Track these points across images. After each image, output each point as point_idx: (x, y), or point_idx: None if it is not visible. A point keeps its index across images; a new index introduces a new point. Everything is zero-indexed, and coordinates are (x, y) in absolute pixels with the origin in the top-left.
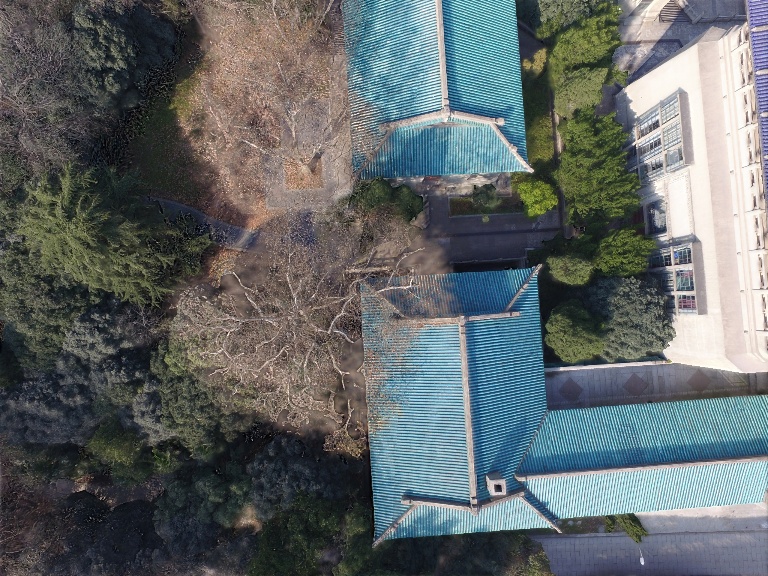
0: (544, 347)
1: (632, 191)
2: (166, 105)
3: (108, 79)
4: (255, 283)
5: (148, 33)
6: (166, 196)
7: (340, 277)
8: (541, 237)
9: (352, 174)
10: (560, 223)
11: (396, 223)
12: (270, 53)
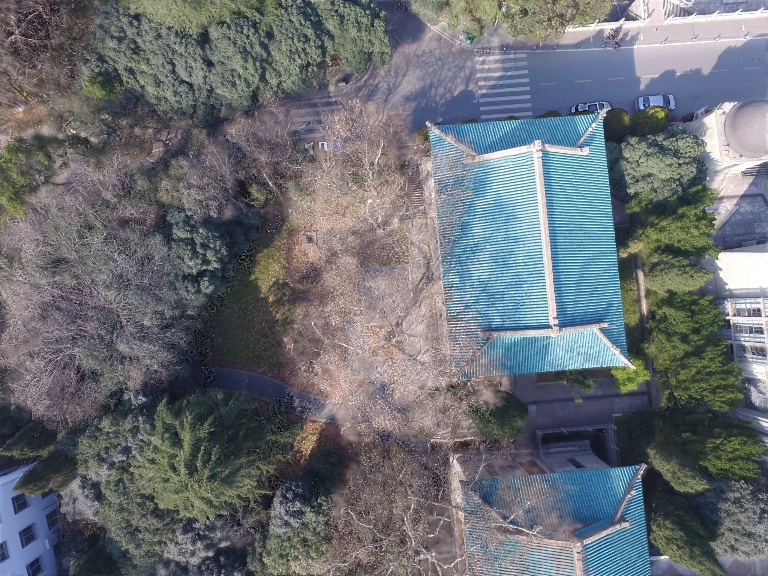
0: (649, 546)
1: (735, 383)
2: (247, 276)
3: (203, 283)
4: (350, 476)
5: (235, 221)
6: (249, 368)
7: (425, 446)
8: (628, 401)
9: (451, 376)
10: (647, 386)
11: (502, 436)
12: (349, 219)
